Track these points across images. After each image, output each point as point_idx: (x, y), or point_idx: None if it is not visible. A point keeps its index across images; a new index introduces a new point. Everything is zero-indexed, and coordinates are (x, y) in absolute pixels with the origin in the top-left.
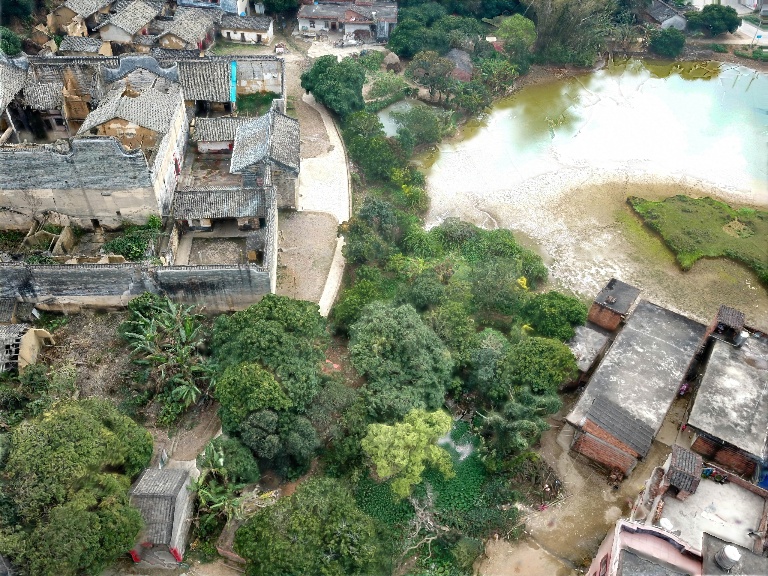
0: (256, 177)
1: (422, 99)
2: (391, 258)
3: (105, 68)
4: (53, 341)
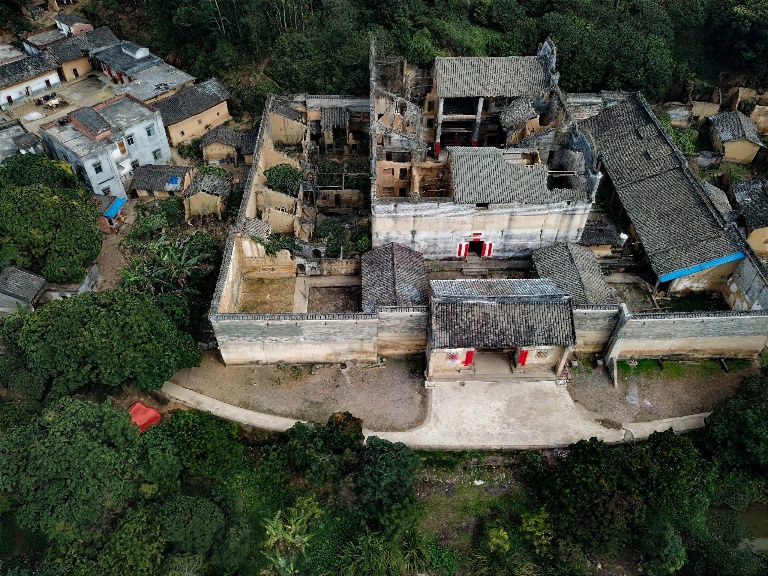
0: None
1: None
2: None
3: None
4: (219, 217)
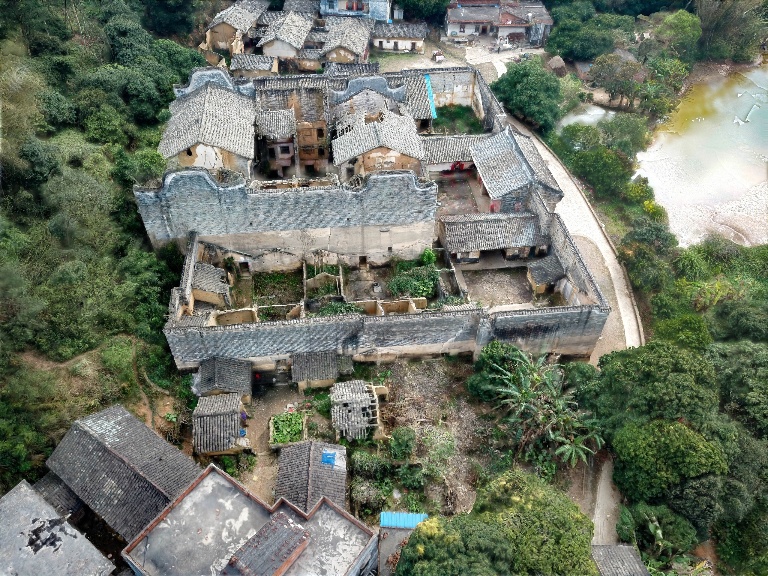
0: (515, 202)
1: (599, 104)
2: (676, 284)
3: (331, 91)
4: None
